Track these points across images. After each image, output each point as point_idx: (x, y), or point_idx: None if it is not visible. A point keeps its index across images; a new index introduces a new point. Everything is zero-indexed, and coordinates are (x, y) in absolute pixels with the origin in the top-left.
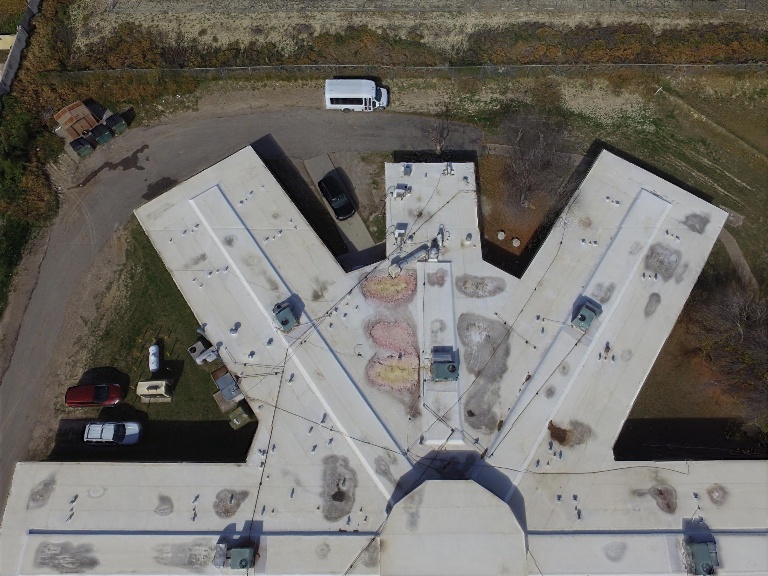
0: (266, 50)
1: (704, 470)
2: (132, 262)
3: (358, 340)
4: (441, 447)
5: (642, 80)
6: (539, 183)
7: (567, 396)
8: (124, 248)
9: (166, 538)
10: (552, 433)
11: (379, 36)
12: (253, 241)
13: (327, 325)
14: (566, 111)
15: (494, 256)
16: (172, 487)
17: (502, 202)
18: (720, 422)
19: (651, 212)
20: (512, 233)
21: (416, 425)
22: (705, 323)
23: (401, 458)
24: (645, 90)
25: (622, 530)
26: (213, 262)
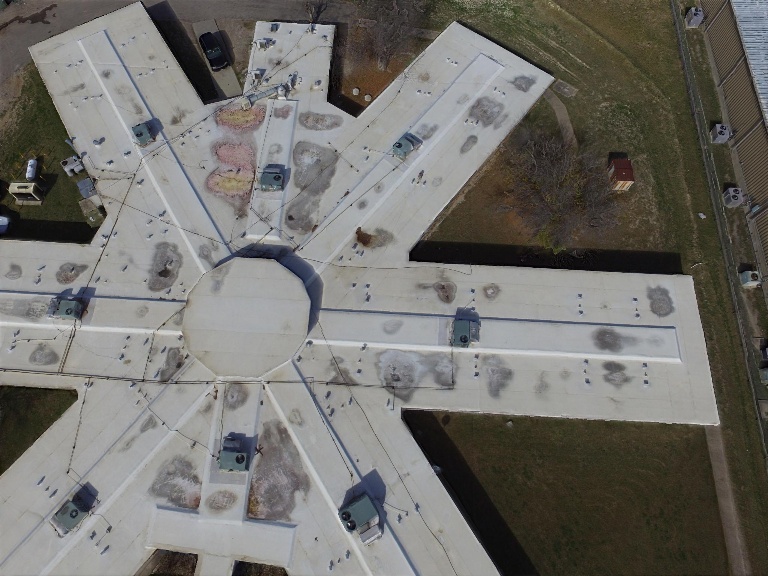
0: None
1: (485, 272)
2: (26, 96)
3: (204, 157)
4: (259, 240)
5: None
6: (377, 33)
7: (378, 210)
8: (21, 84)
9: (11, 295)
10: (359, 237)
11: None
12: (127, 75)
13: (180, 144)
14: None
15: (346, 107)
16: (23, 258)
17: (362, 65)
18: (519, 248)
19: (484, 72)
20: (366, 91)
21: (242, 224)
22: (511, 160)
23: (223, 247)
24: None
25: (403, 312)
26: (90, 90)
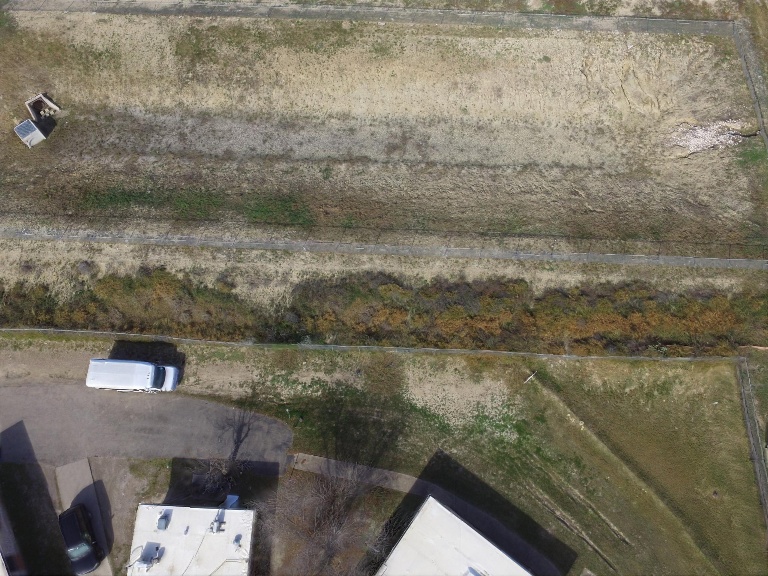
0: (33, 297)
1: None
2: None
3: None
4: None
5: (509, 362)
6: None
7: None
8: None
9: None
10: None
11: (177, 285)
12: None
13: None
14: (406, 403)
15: None
16: None
17: (298, 550)
18: None
19: None
20: None
21: None
22: None
23: None
24: (513, 375)
25: None
26: None
